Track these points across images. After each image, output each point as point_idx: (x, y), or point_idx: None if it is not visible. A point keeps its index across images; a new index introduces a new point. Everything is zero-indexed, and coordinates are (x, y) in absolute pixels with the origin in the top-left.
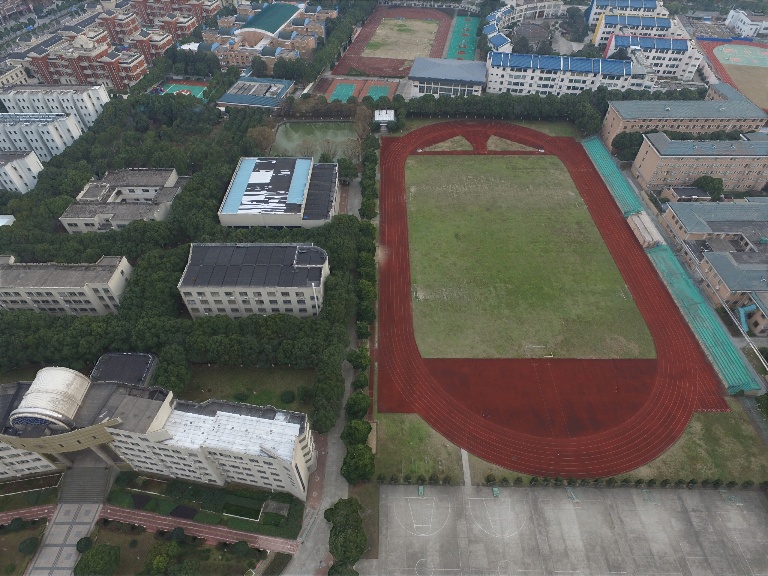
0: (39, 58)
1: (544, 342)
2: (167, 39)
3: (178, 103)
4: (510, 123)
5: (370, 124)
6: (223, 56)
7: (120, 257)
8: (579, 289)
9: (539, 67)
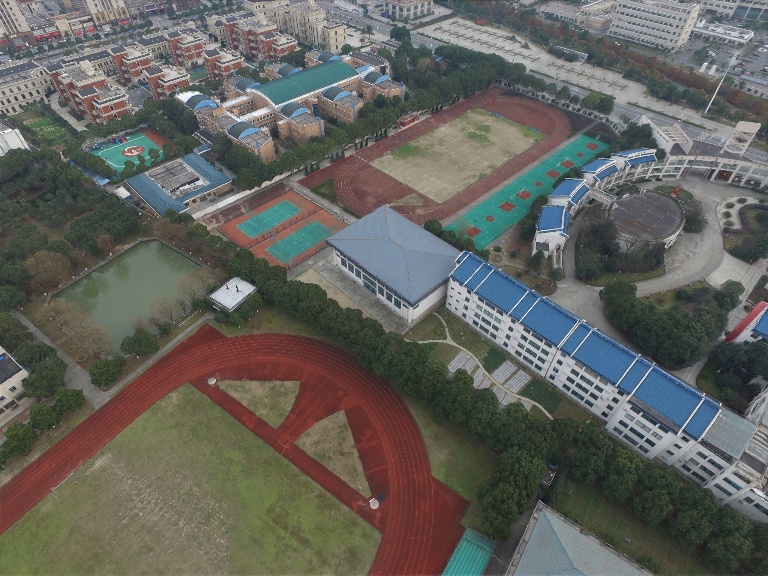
0: (50, 74)
1: None
2: (179, 80)
3: (67, 173)
4: (403, 398)
5: (192, 302)
6: (202, 119)
7: None
8: None
9: (522, 320)
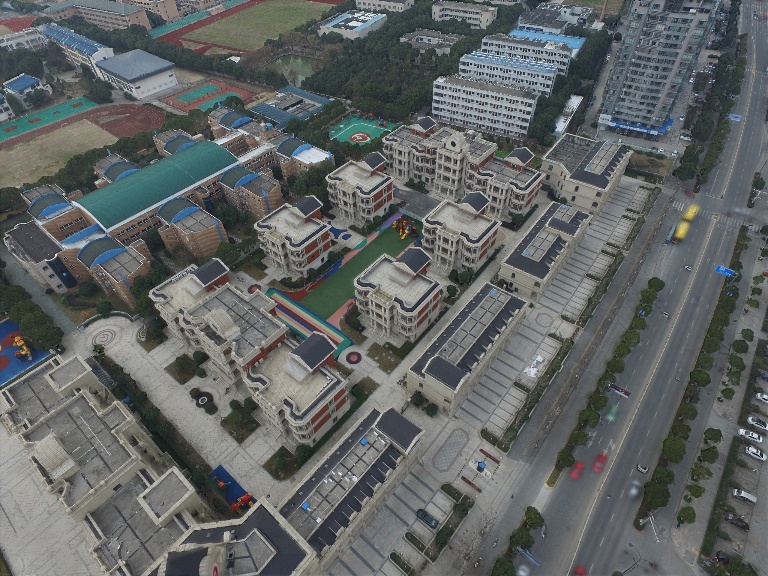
0: None
1: (303, 2)
2: None
3: None
4: None
5: None
6: None
7: (435, 6)
8: (271, 7)
9: None
